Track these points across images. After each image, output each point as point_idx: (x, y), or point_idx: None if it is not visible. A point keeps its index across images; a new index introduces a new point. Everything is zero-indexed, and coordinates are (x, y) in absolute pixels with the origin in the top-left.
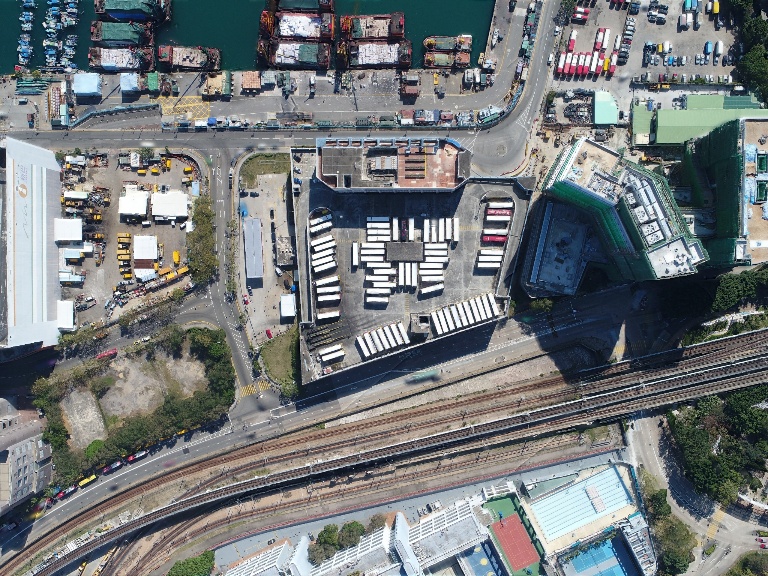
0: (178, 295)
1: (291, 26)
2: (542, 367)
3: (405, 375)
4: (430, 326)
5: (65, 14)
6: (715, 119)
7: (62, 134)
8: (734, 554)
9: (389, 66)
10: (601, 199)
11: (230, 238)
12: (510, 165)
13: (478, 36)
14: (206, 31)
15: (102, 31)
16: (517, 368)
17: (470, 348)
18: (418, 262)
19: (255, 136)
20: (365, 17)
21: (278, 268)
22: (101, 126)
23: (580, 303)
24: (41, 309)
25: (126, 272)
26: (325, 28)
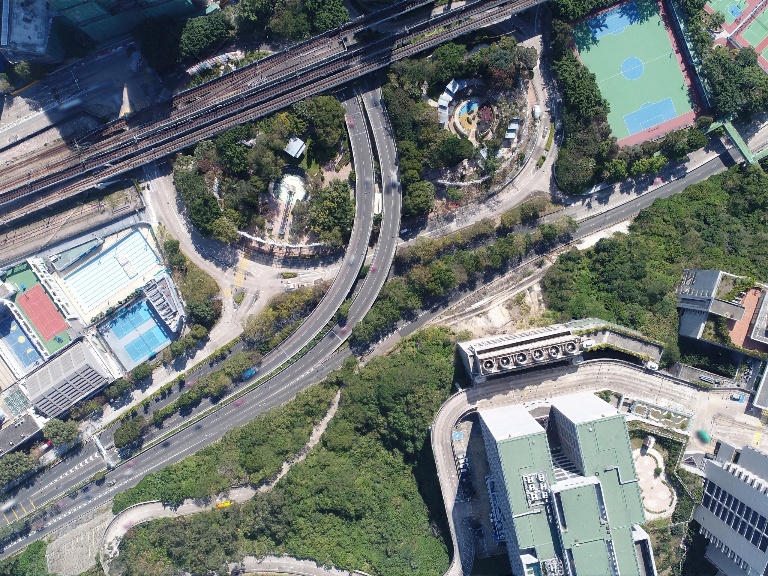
0: None
1: None
2: (48, 138)
3: None
4: None
5: None
6: None
7: None
8: (263, 299)
9: None
10: None
11: None
12: None
13: None
14: None
15: None
16: (27, 143)
17: None
18: None
19: None
20: None
21: None
22: None
23: (81, 72)
24: None
25: None
26: None
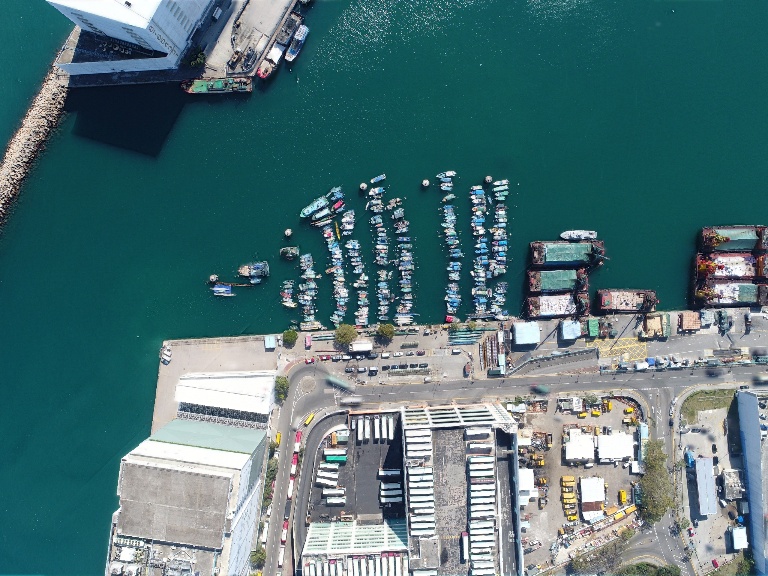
0: (629, 535)
1: (728, 267)
2: None
3: None
4: None
5: (494, 262)
6: None
7: (498, 382)
8: None
9: None
10: None
11: (672, 473)
12: None
13: None
14: (637, 273)
15: (541, 282)
16: None
17: None
18: None
19: (694, 374)
20: None
21: (724, 501)
22: (538, 372)
23: None
24: None
25: (571, 514)
26: (767, 271)
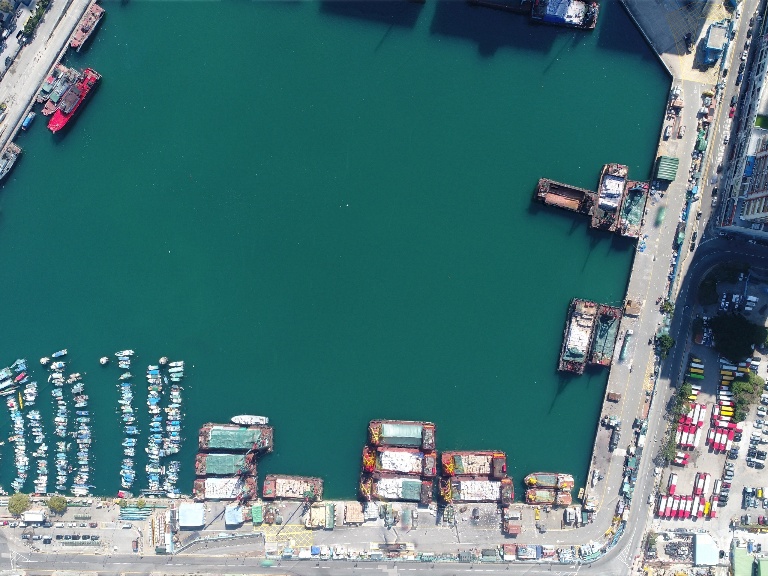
0: None
1: (393, 463)
2: None
3: None
4: None
5: (167, 441)
6: None
7: (166, 559)
8: None
9: (490, 500)
10: None
11: None
12: None
13: (577, 471)
14: (308, 460)
15: (206, 466)
16: None
17: None
18: None
19: (358, 566)
20: (466, 454)
21: None
22: (205, 552)
23: None
24: None
25: None
26: (429, 471)
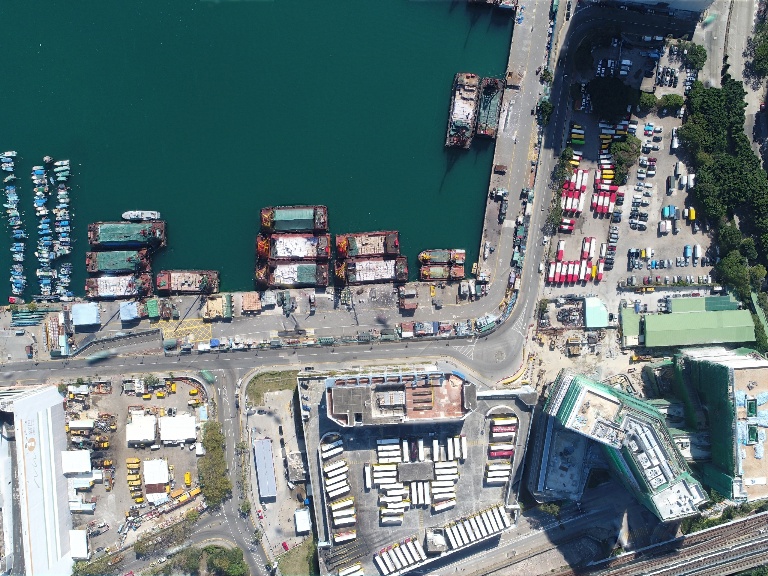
0: (192, 517)
1: (288, 248)
2: (552, 561)
3: (421, 575)
4: (445, 539)
5: (57, 243)
6: (699, 322)
7: (62, 363)
8: None
9: (386, 280)
10: (605, 443)
11: (240, 455)
12: (509, 370)
13: (470, 247)
14: (202, 253)
15: (98, 262)
16: (528, 563)
17: (482, 545)
18: (429, 481)
19: (259, 355)
20: (360, 235)
21: (290, 483)
22: (102, 353)
23: (584, 496)
24: (55, 549)
25: (137, 496)
26: (322, 251)
